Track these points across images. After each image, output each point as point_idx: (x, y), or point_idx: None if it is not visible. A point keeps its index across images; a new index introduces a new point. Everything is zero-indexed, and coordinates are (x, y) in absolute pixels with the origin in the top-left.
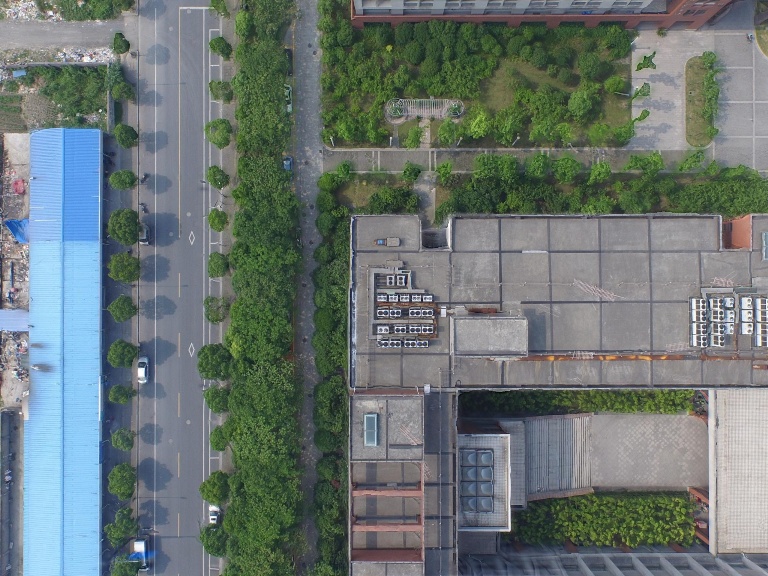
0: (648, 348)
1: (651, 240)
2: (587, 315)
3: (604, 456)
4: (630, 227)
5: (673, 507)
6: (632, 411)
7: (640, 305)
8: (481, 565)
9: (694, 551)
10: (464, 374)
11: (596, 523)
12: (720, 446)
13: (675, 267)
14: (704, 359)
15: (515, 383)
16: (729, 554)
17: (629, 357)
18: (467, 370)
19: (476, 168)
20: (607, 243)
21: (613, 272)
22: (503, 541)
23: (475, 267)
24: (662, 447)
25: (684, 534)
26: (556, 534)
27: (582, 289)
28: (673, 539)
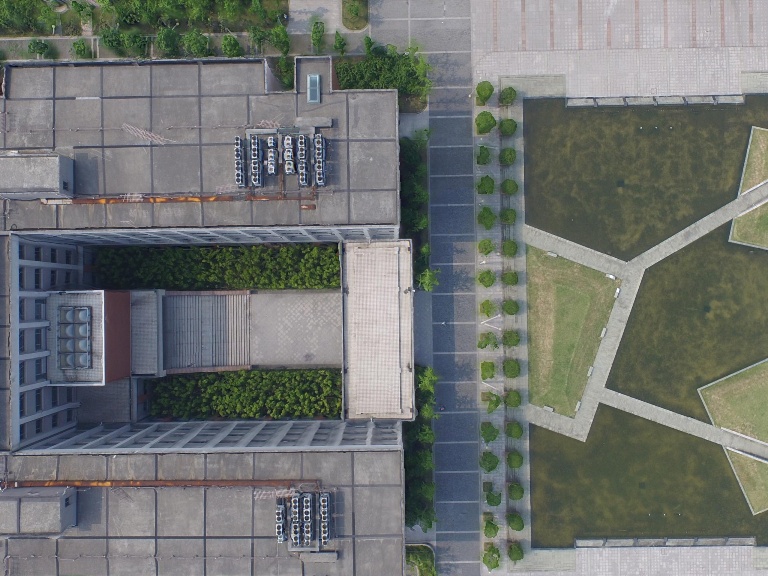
0: (198, 190)
1: (201, 85)
2: (138, 159)
3: (264, 335)
4: (181, 73)
5: (321, 380)
6: (279, 286)
7: (189, 148)
8: (97, 427)
9: (330, 419)
10: (20, 218)
11: (243, 396)
12: (350, 313)
13: (224, 111)
14: (250, 199)
15: (70, 227)
16: (358, 419)
17: (178, 199)
18: (23, 214)
19: (137, 54)
20: (158, 89)
21: (163, 116)
22: (145, 412)
23: (29, 114)
24: (321, 325)
25: (329, 405)
26: (204, 407)
27: (131, 133)
28: (319, 411)
